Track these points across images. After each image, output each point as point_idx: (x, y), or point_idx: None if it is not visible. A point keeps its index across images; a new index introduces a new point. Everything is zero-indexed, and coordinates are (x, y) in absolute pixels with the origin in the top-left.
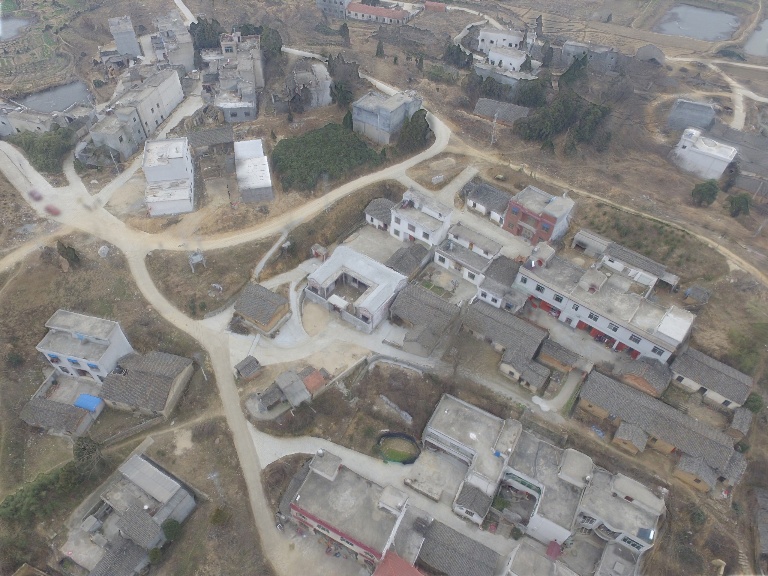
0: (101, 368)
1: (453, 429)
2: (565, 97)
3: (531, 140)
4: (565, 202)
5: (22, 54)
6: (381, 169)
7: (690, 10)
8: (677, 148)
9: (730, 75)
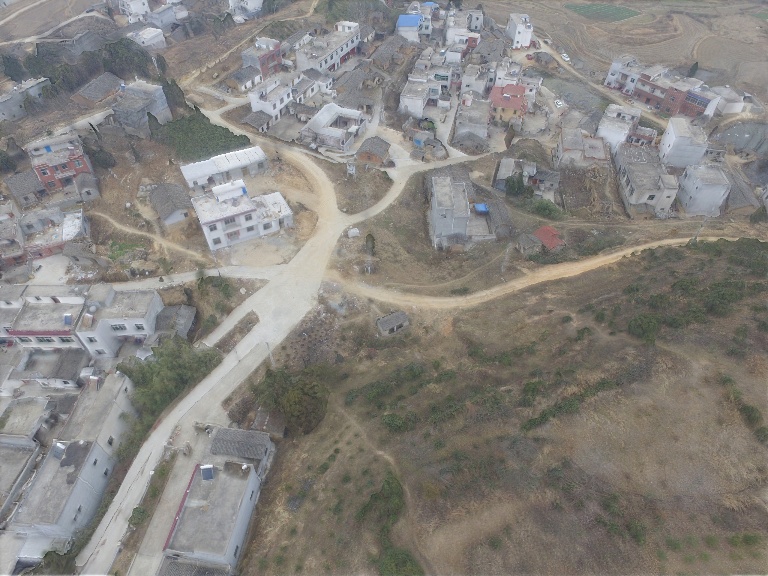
0: None
1: (419, 94)
2: (115, 45)
3: None
4: (264, 39)
5: None
6: None
7: None
8: (143, 45)
9: None
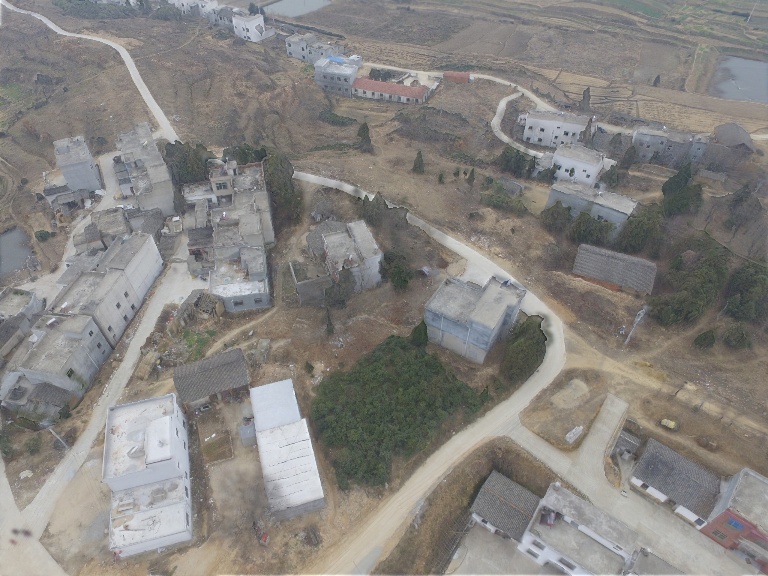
0: None
1: None
2: (715, 259)
3: (674, 324)
4: None
5: None
6: (481, 414)
7: (741, 64)
8: None
9: None
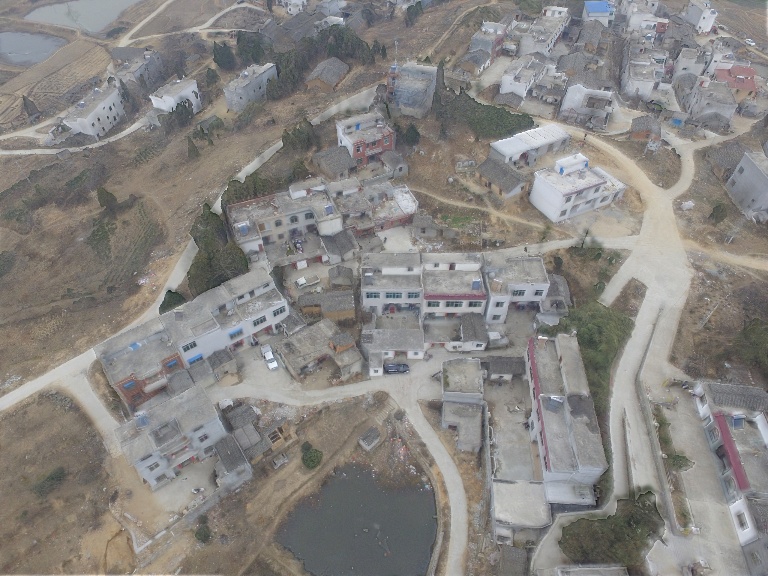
0: None
1: (647, 76)
2: (339, 30)
3: None
4: (489, 23)
5: None
6: None
7: None
8: None
9: (160, 33)
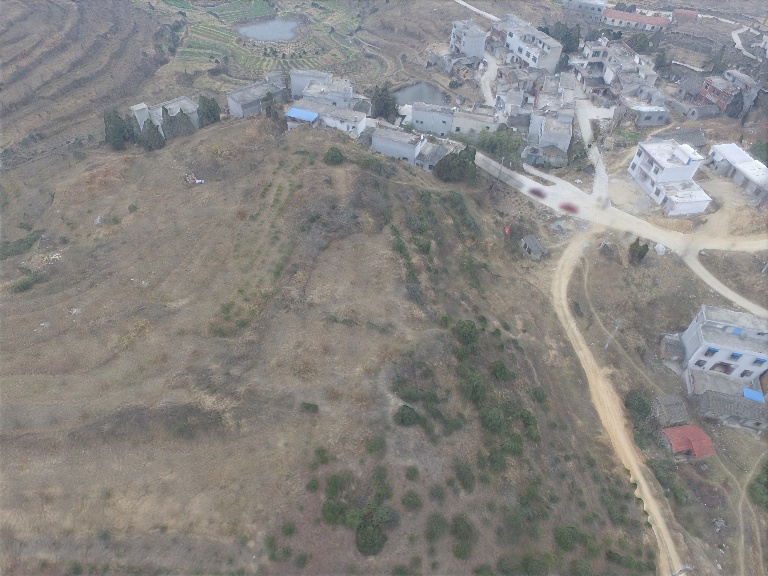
0: (767, 363)
1: None
2: None
3: None
4: None
5: (323, 55)
6: None
7: None
8: None
9: None
